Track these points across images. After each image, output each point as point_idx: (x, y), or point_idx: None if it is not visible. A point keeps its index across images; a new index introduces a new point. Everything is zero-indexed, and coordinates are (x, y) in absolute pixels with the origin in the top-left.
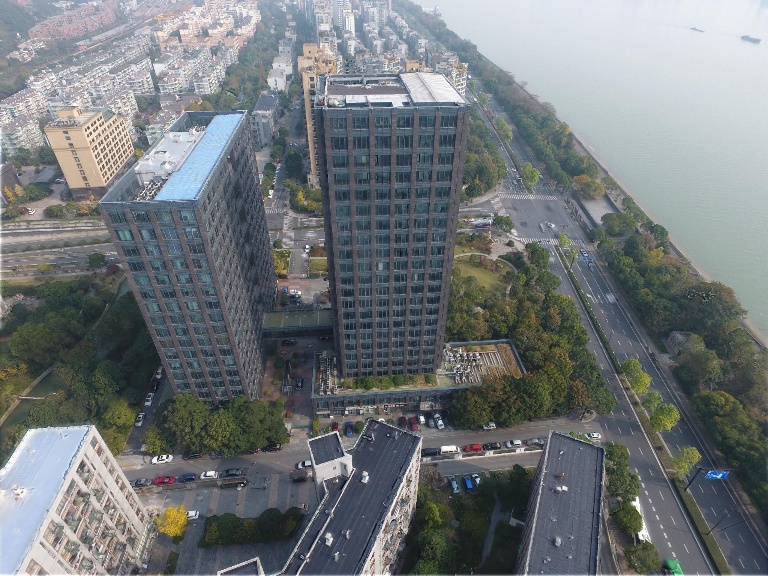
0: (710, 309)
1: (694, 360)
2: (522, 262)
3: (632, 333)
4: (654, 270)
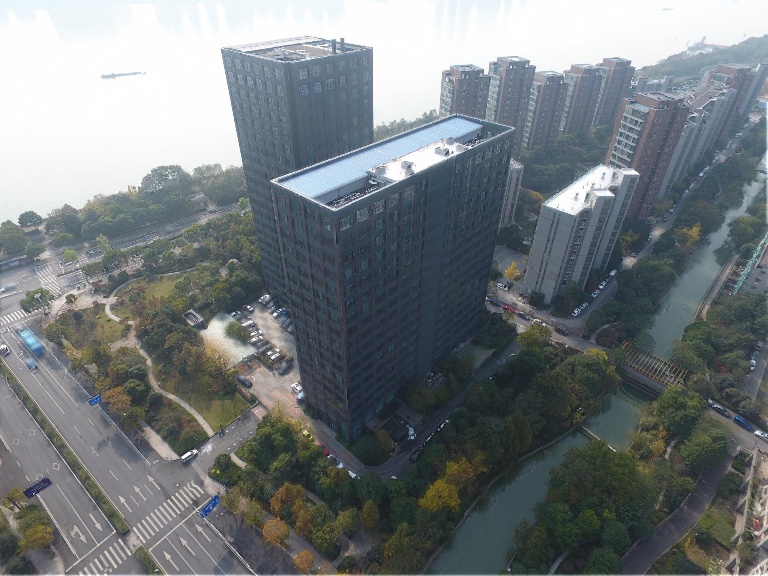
0: (181, 175)
1: (227, 185)
2: (125, 271)
3: (191, 221)
4: (122, 204)
